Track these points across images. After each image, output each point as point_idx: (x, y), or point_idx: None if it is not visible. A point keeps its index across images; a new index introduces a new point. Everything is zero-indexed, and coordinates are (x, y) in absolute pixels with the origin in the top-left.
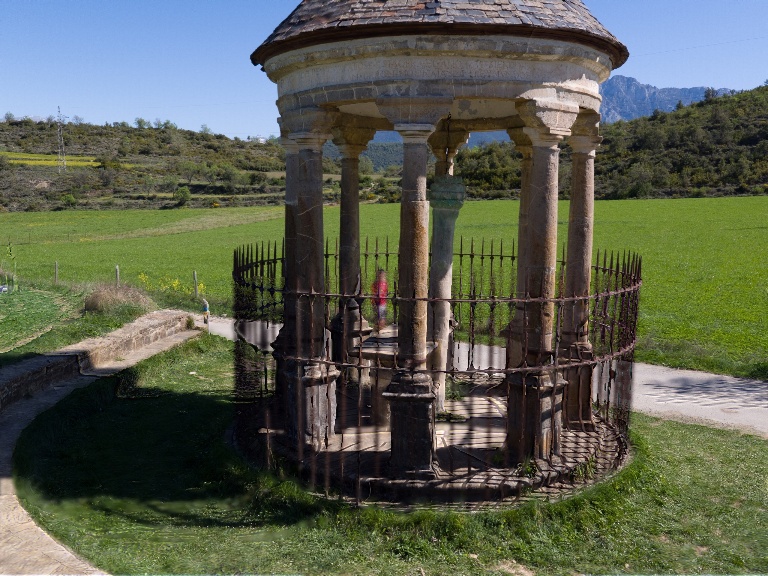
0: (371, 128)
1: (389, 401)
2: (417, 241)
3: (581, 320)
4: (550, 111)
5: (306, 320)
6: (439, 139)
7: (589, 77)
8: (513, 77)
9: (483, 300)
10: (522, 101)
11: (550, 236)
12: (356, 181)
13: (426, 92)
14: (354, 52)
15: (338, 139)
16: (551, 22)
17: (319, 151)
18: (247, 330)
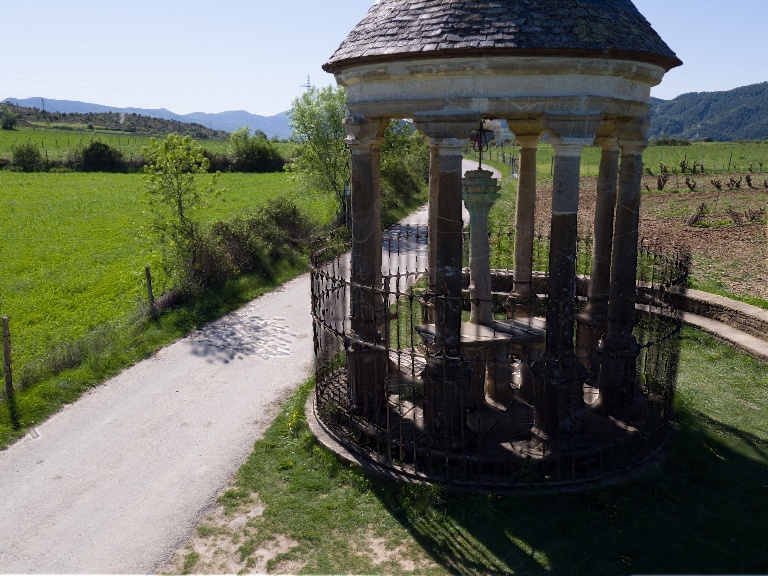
0: None
1: None
2: None
3: None
4: None
5: None
6: None
7: None
8: None
9: None
10: None
11: None
12: None
13: None
14: None
15: None
16: None
17: None
18: None
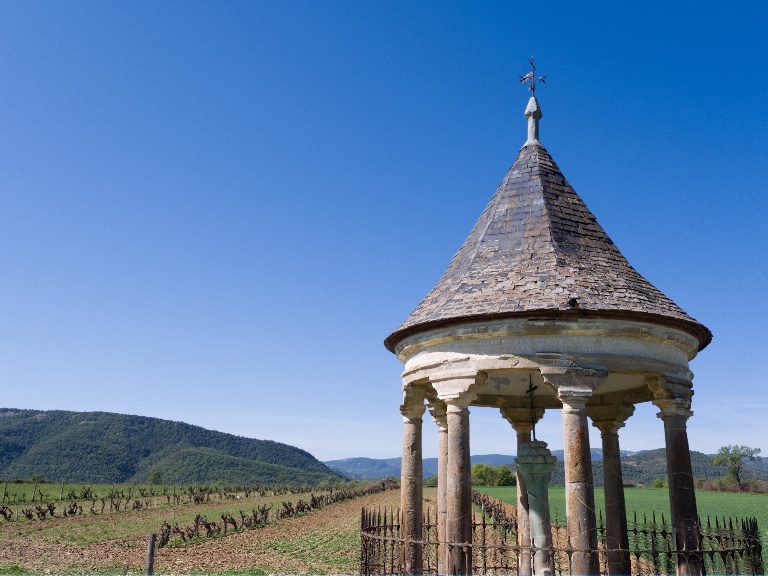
0: None
1: None
2: None
3: None
4: None
5: None
6: None
7: None
8: None
9: None
10: None
11: None
12: None
13: None
14: None
15: None
16: None
17: None
18: None
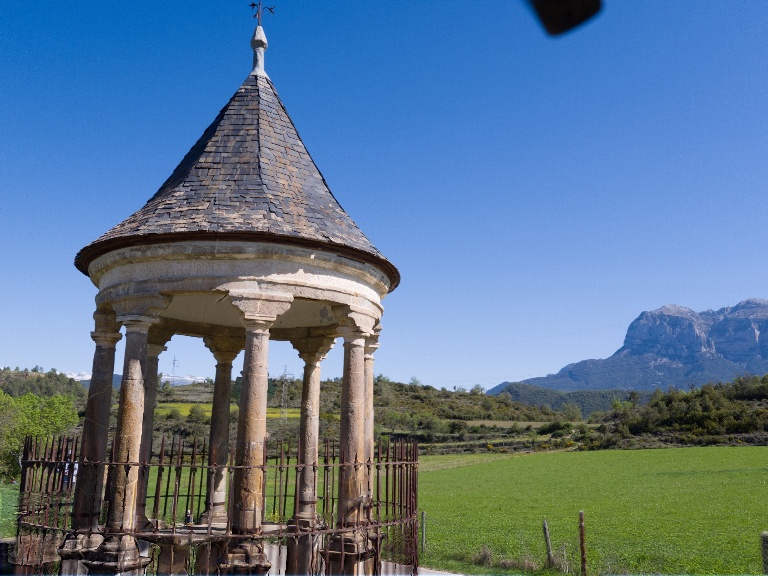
0: (243, 337)
1: None
2: (125, 415)
3: (348, 509)
4: (248, 300)
5: (78, 495)
6: (305, 345)
7: (313, 272)
8: (211, 274)
9: (134, 463)
10: (227, 293)
11: (251, 412)
12: (226, 384)
13: (139, 290)
14: (103, 265)
15: (211, 347)
16: (231, 228)
17: (108, 347)
18: (269, 553)
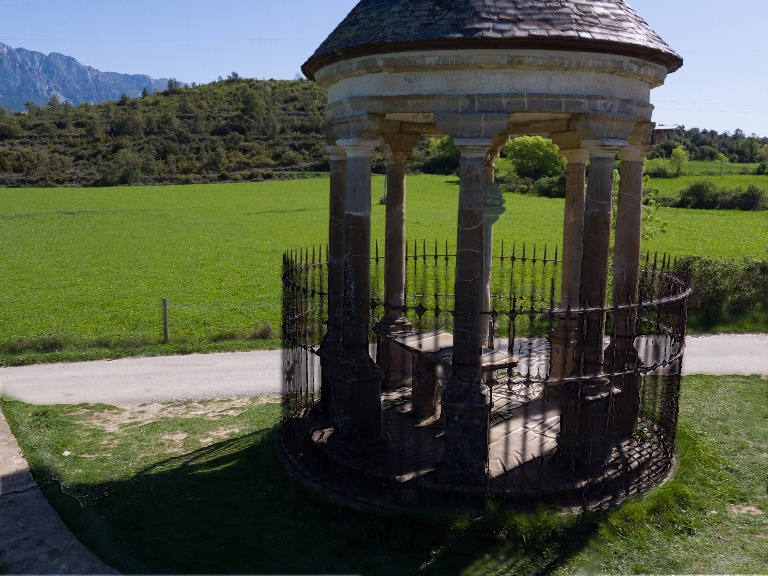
0: None
1: (590, 405)
2: None
3: None
4: None
5: (477, 342)
6: (398, 141)
7: None
8: None
9: None
10: (639, 122)
11: None
12: None
13: (623, 110)
14: (574, 64)
15: None
16: None
17: None
18: None
